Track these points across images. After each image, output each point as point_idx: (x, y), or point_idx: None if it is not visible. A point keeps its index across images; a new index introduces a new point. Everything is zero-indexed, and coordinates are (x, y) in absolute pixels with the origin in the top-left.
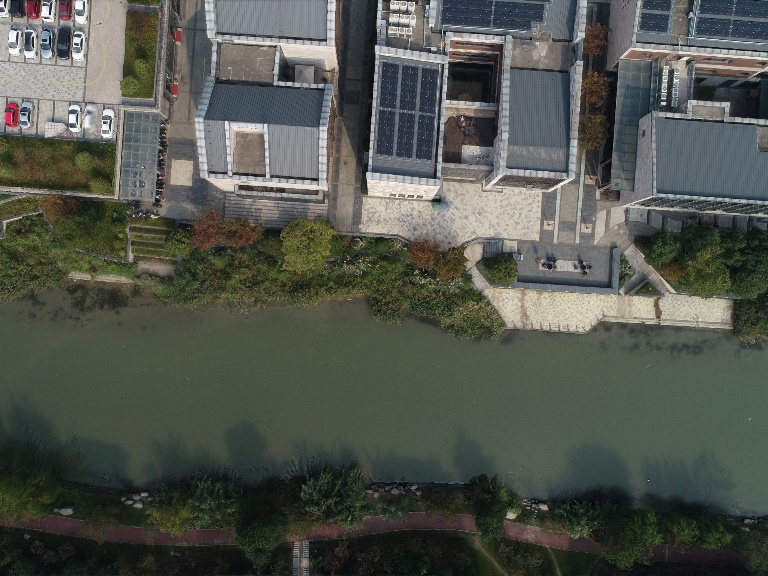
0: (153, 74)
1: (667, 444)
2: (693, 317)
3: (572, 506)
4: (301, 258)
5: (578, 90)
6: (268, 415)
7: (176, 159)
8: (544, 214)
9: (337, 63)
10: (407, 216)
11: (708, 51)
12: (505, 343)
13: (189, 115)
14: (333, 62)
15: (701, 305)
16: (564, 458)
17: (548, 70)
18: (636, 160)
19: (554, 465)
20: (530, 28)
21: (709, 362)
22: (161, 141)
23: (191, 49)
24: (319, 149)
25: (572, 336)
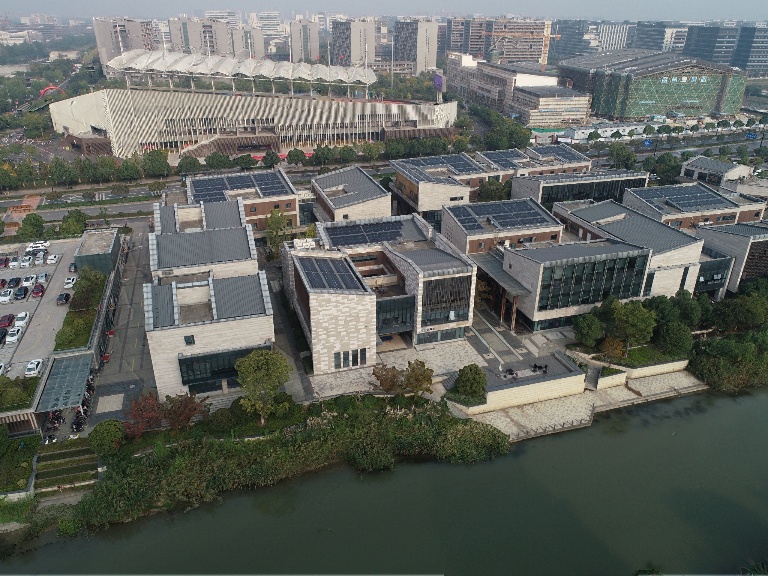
0: (89, 334)
1: None
2: (668, 388)
3: (747, 575)
4: (261, 373)
5: None
6: None
7: (104, 396)
8: (480, 351)
9: None
10: (358, 379)
11: (516, 230)
12: (519, 455)
13: (120, 369)
14: None
15: (665, 380)
16: (684, 541)
17: None
18: (518, 281)
19: (682, 555)
20: (396, 239)
21: (721, 416)
22: (88, 387)
23: (123, 337)
24: (261, 287)
25: (580, 431)
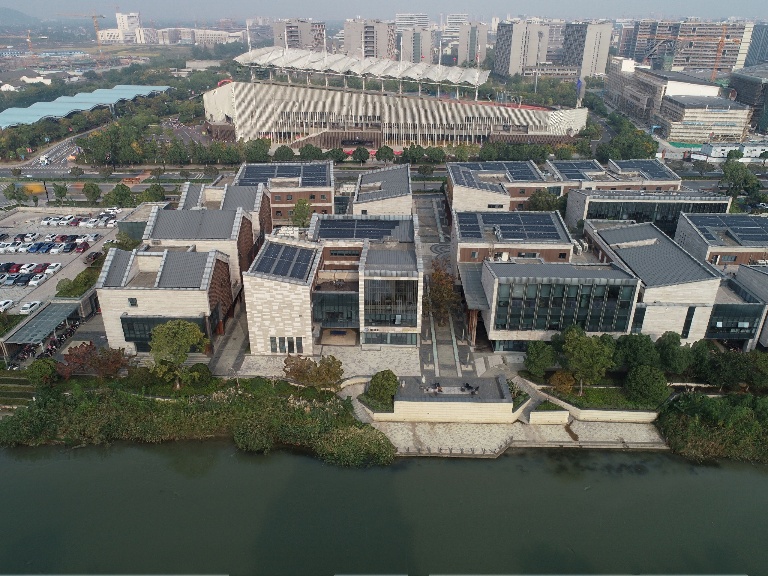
0: (88, 288)
1: (660, 575)
2: (616, 439)
3: None
4: (166, 340)
5: (418, 244)
6: (51, 555)
7: (77, 341)
8: (423, 361)
9: (239, 273)
10: None
11: (515, 243)
12: (398, 470)
13: None
14: (236, 270)
15: (619, 429)
16: None
17: (398, 250)
18: (485, 295)
19: None
20: (382, 238)
21: (663, 483)
22: None
23: None
24: (206, 263)
25: (480, 461)
